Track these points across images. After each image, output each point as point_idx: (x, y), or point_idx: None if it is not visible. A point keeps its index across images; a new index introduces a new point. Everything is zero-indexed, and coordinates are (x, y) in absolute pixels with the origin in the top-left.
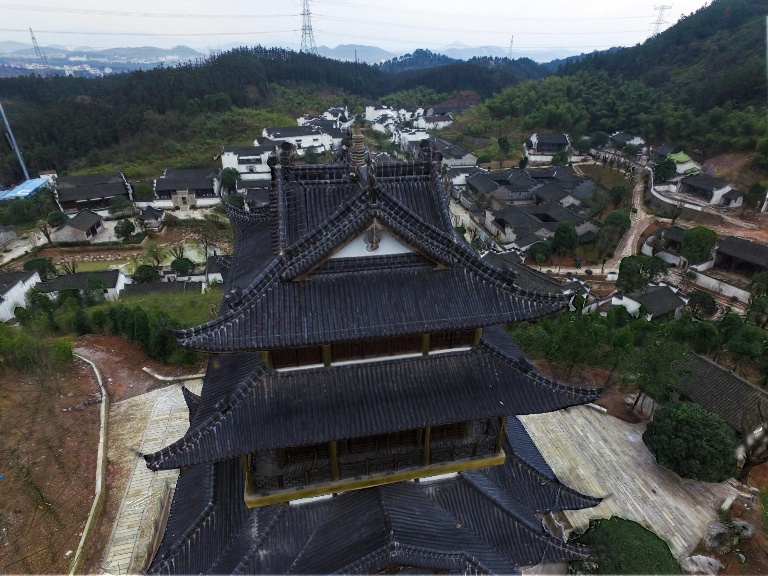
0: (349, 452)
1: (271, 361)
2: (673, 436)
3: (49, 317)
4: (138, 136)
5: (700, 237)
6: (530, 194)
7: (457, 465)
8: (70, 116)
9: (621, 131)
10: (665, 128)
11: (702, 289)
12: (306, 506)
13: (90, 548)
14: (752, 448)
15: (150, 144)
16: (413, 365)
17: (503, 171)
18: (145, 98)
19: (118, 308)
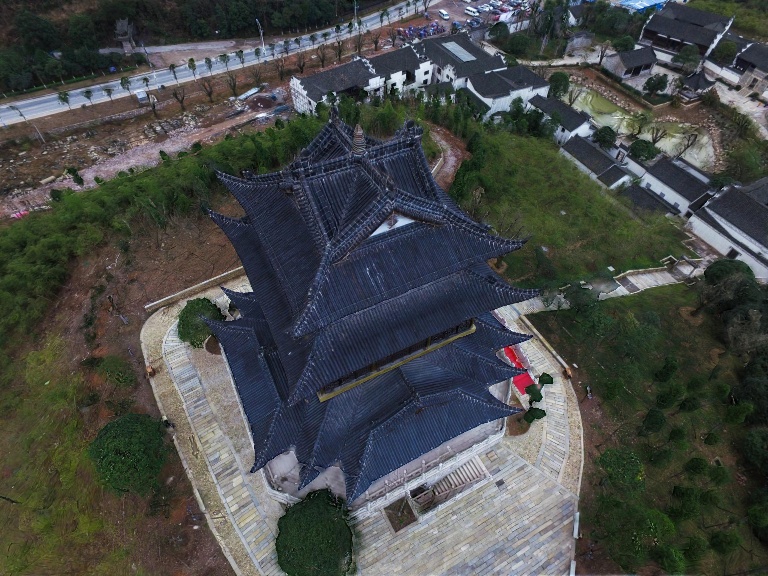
0: None
1: None
2: None
3: (465, 126)
4: None
5: None
6: None
7: None
8: None
9: None
10: None
11: None
12: None
13: None
14: None
15: None
16: None
17: None
18: None
19: (482, 148)
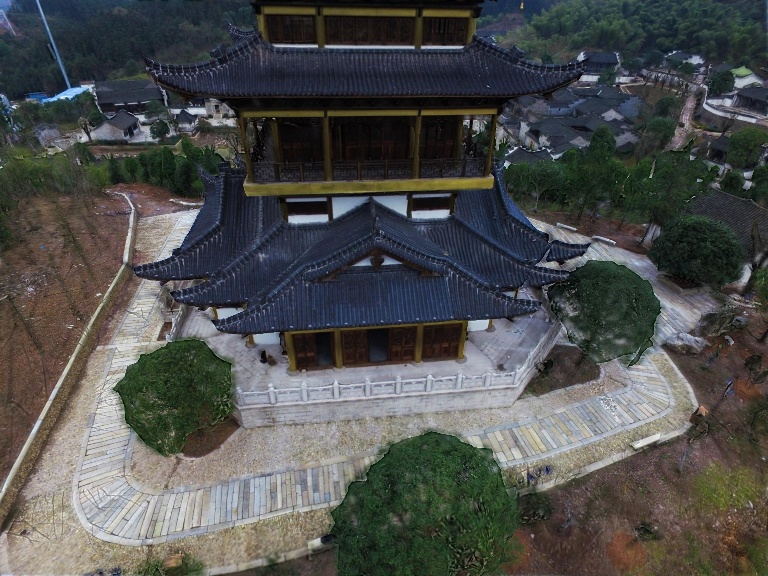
0: None
1: (267, 32)
2: (677, 242)
3: None
4: (173, 48)
5: (749, 139)
6: (570, 110)
7: (446, 181)
8: (108, 28)
9: (679, 50)
10: (729, 45)
11: None
12: (304, 227)
13: (117, 298)
14: (760, 260)
15: (185, 56)
16: (405, 57)
17: None
18: (180, 10)
19: (148, 153)
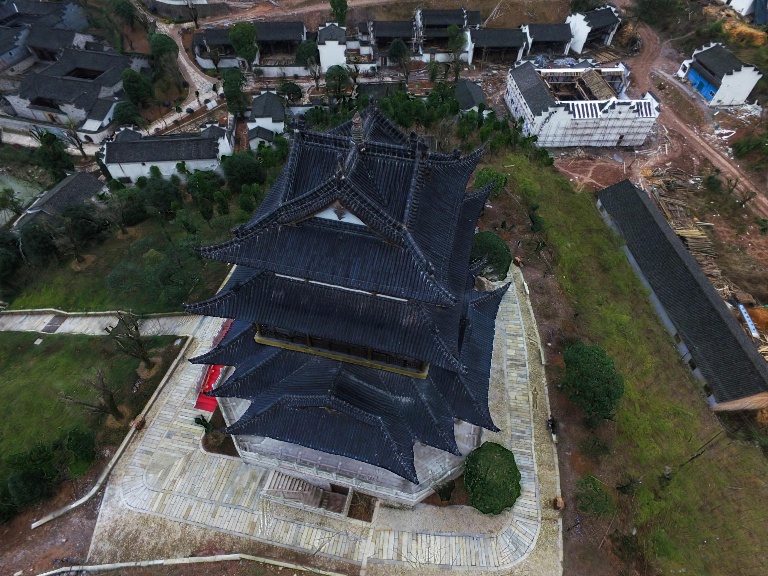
0: None
1: None
2: None
3: None
4: None
5: (246, 35)
6: (22, 49)
7: None
8: None
9: None
10: None
11: (272, 79)
12: None
13: None
14: None
15: None
16: None
17: None
18: None
19: None
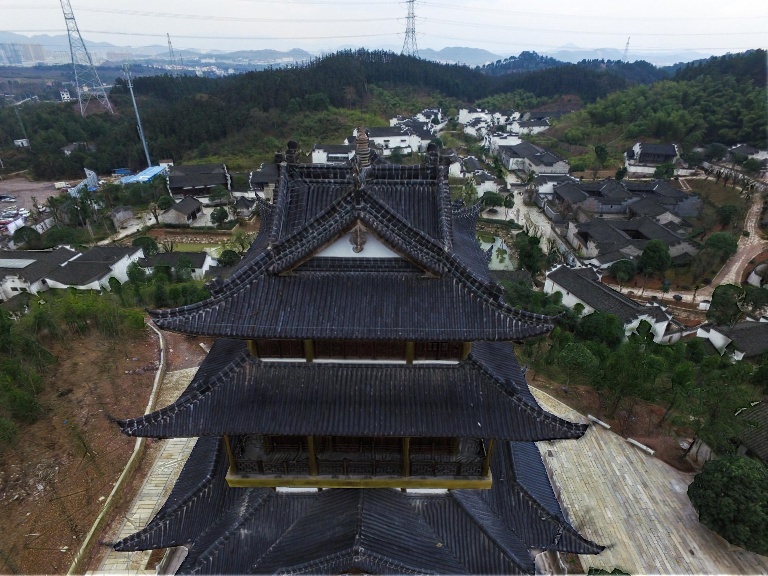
0: (334, 450)
1: (255, 350)
2: (722, 494)
3: (135, 289)
4: (243, 131)
5: None
6: (623, 208)
7: (438, 481)
8: (189, 111)
9: (744, 143)
10: None
11: None
12: (292, 495)
13: (121, 498)
14: None
15: (252, 139)
16: (395, 372)
17: (596, 181)
18: (253, 97)
19: (189, 287)
